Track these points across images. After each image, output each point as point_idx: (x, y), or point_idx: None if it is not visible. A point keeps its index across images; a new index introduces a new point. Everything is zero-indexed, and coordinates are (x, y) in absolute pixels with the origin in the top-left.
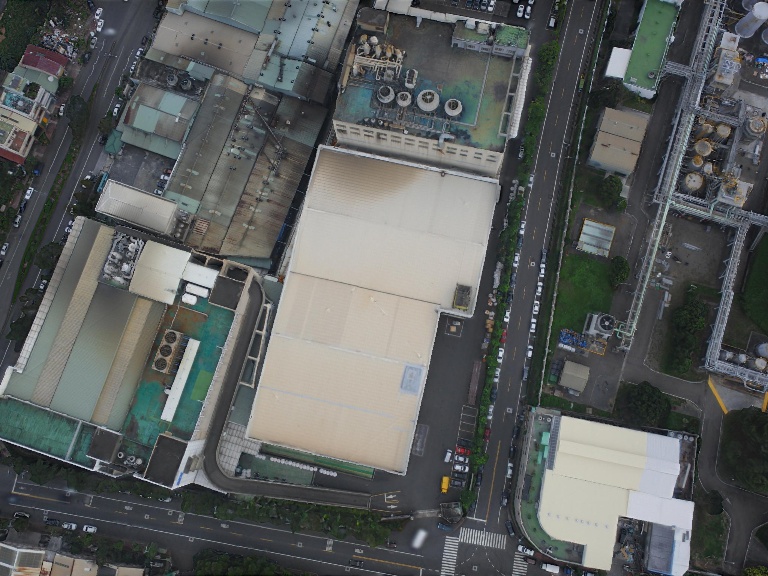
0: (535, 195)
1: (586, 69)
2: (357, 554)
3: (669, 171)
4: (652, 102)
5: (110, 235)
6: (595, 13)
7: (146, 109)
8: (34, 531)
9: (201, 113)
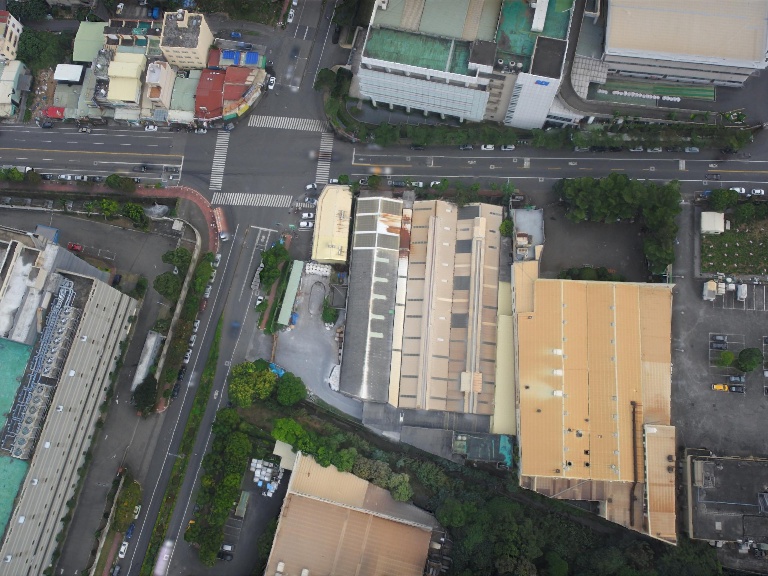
0: None
1: None
2: (712, 169)
3: None
4: None
5: None
6: None
7: None
8: None
9: None
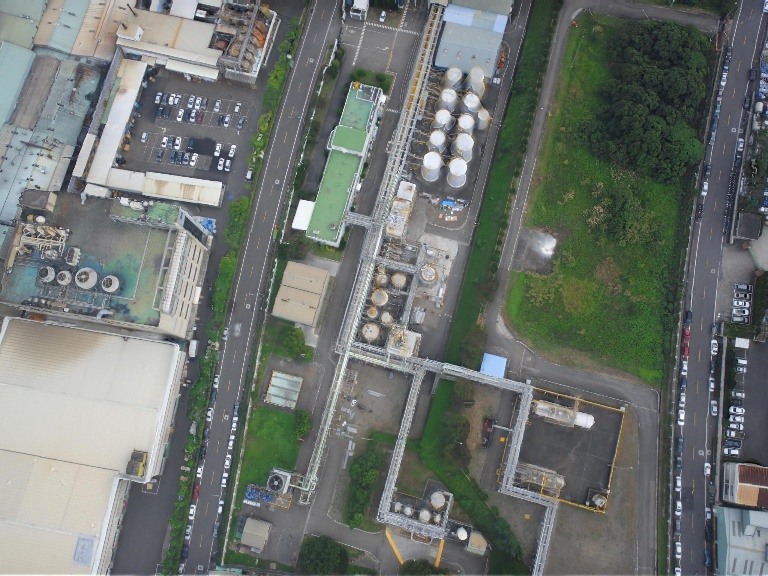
0: (230, 348)
1: (281, 219)
2: None
3: (349, 321)
4: (341, 250)
5: None
6: (291, 163)
7: None
8: None
9: None
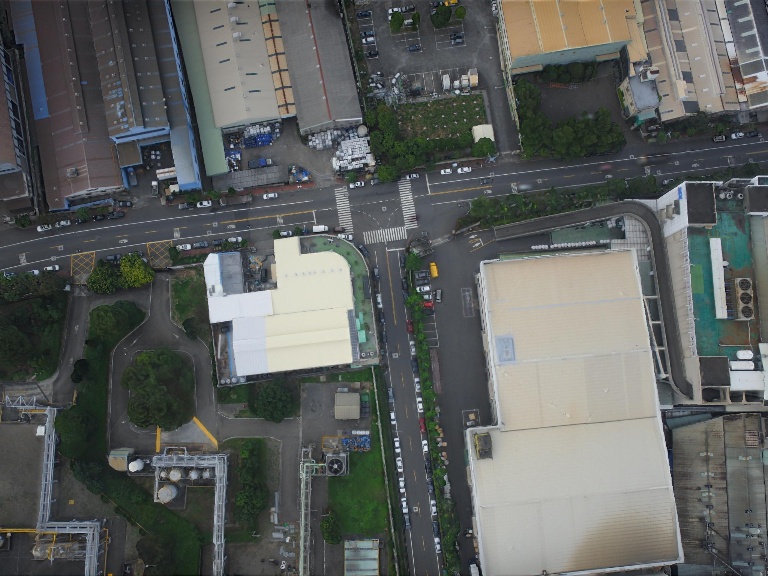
0: None
1: None
2: (489, 189)
3: None
4: None
5: None
6: None
7: None
8: (766, 122)
9: None
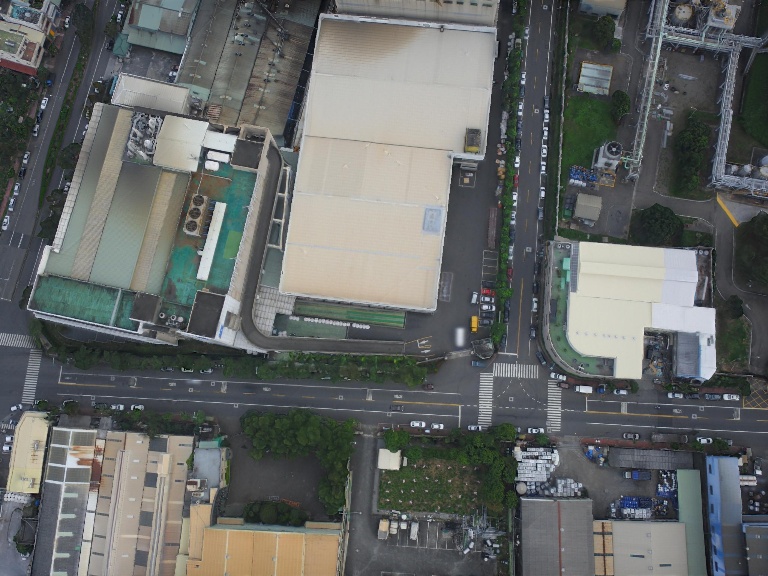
0: (532, 47)
1: None
2: (397, 399)
3: (659, 6)
4: None
5: (129, 117)
6: None
7: (149, 8)
8: (84, 415)
9: (202, 7)
